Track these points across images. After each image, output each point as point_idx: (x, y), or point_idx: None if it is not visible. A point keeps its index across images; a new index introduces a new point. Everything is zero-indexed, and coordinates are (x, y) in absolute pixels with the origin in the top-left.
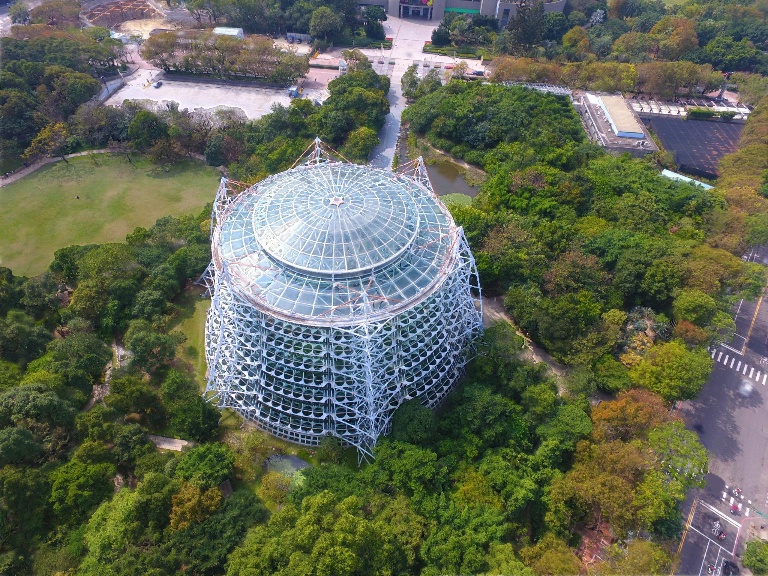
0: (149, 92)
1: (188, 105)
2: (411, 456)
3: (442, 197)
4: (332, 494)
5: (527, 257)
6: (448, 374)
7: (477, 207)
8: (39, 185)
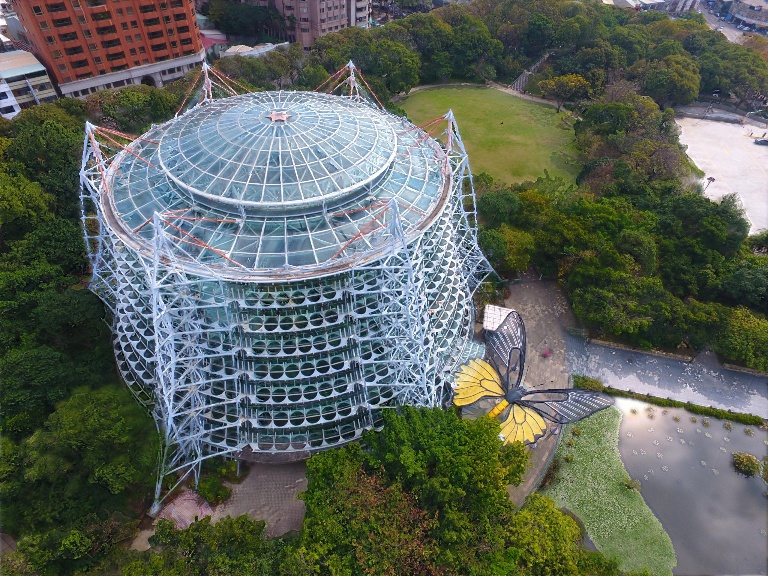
0: (739, 139)
1: (735, 168)
2: (9, 277)
3: (640, 501)
4: (4, 205)
5: (308, 564)
6: (147, 389)
7: (592, 561)
8: (516, 106)
